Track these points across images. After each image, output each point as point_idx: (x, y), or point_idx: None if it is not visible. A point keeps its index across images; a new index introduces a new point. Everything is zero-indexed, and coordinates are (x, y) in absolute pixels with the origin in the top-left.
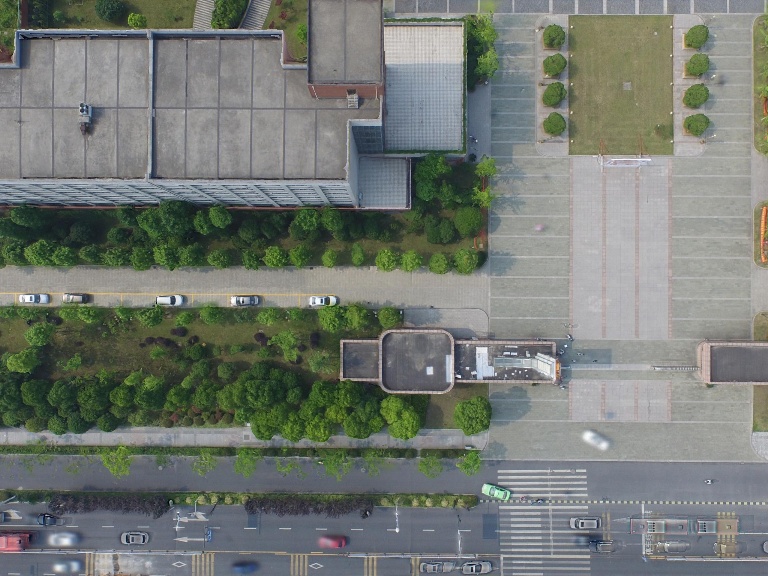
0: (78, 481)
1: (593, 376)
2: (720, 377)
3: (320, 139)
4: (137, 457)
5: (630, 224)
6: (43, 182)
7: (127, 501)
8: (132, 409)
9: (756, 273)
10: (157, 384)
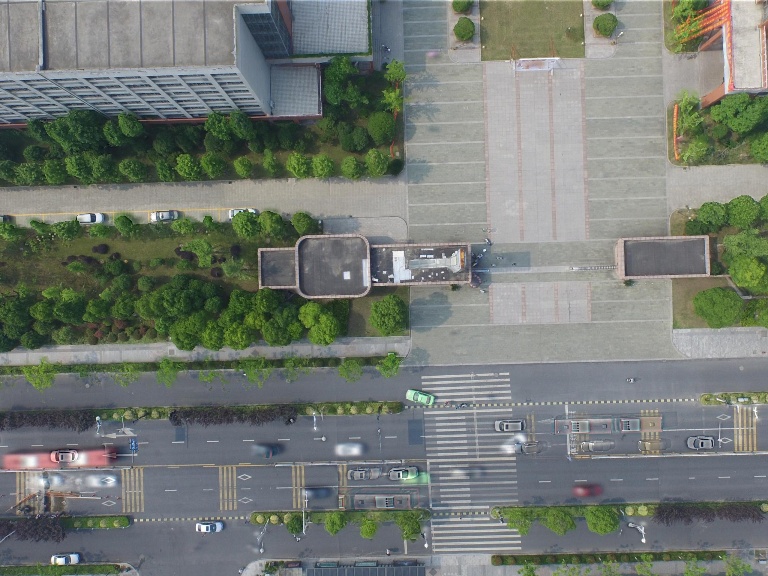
0: (6, 401)
1: (513, 279)
2: (635, 272)
3: (209, 26)
4: (64, 376)
5: (544, 127)
6: None
7: (52, 416)
8: (55, 326)
9: (671, 171)
10: (76, 297)
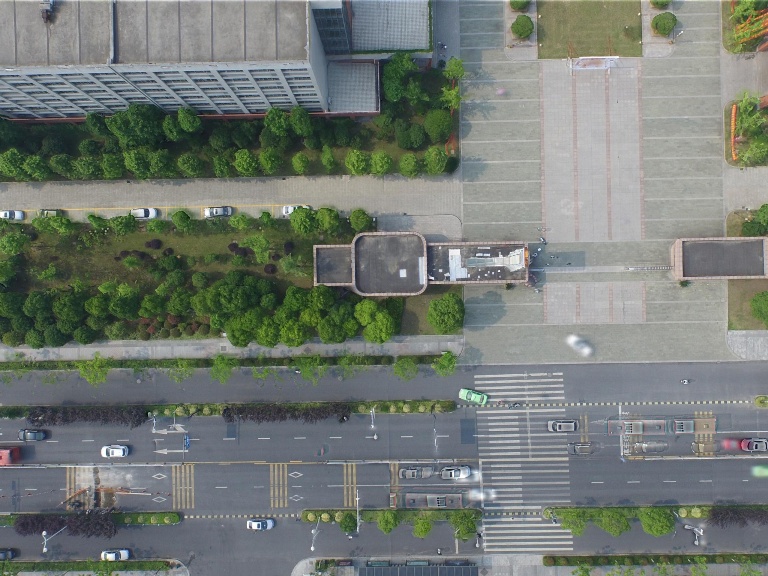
0: (57, 396)
1: (567, 279)
2: (693, 273)
3: (280, 21)
4: (115, 371)
5: (601, 126)
6: (7, 72)
7: (105, 411)
8: (108, 321)
9: (728, 172)
10: (131, 292)
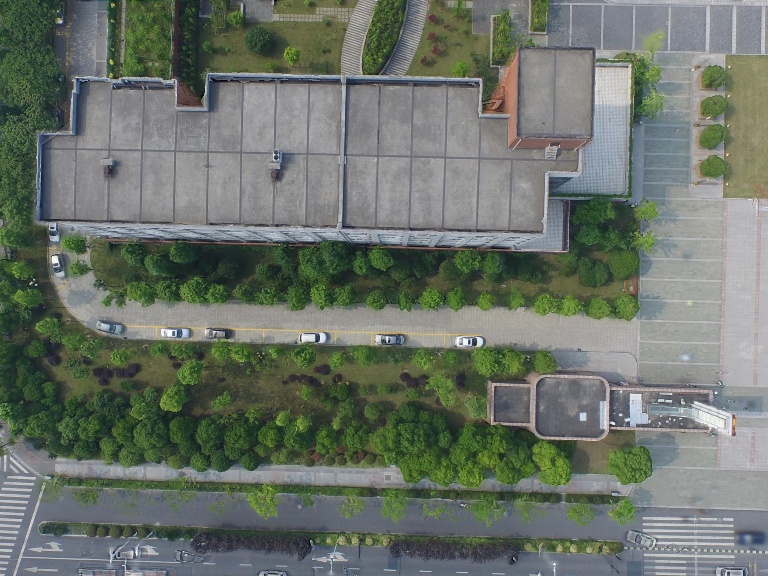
0: (216, 518)
1: (743, 424)
2: None
3: (515, 190)
4: (276, 495)
5: None
6: (228, 228)
7: (271, 541)
8: (276, 448)
9: None
10: (307, 425)
